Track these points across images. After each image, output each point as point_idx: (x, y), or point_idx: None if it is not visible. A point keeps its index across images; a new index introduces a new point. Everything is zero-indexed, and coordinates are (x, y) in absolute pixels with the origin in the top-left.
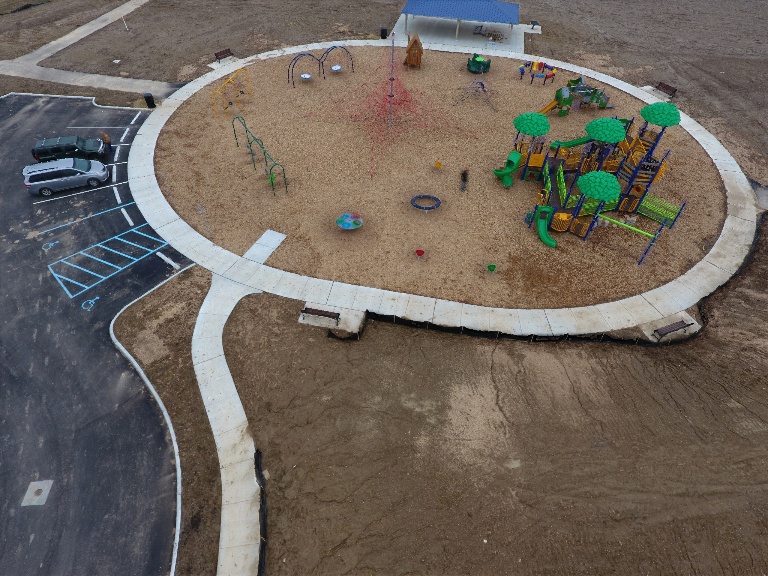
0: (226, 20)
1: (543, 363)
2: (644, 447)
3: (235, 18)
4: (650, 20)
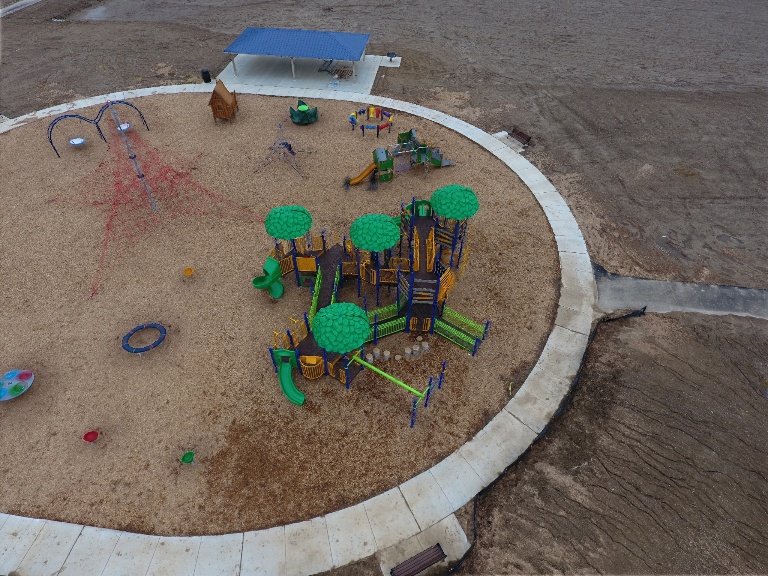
0: (20, 66)
1: None
2: None
3: (33, 63)
4: (530, 44)
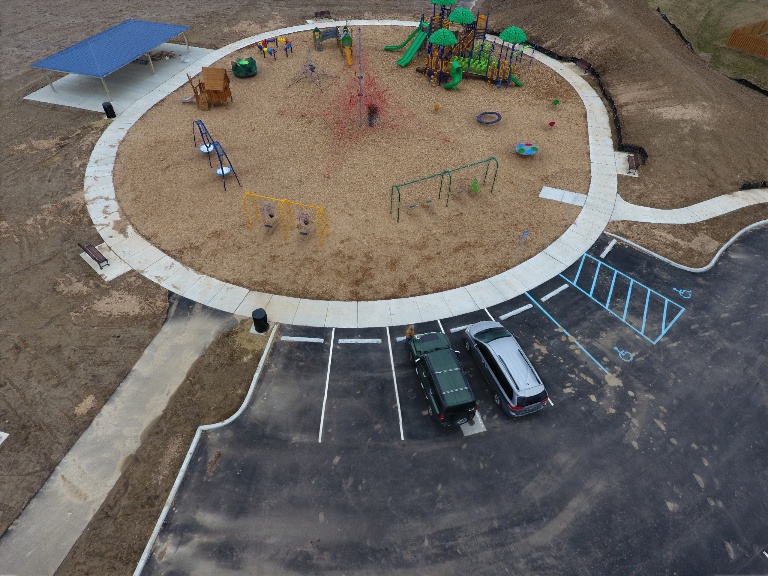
0: None
1: (628, 97)
2: None
3: None
4: None
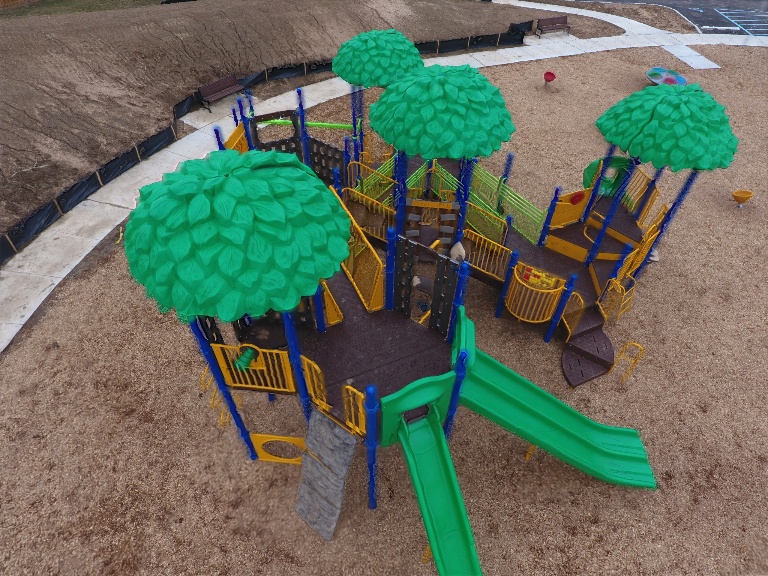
0: None
1: None
2: (266, 3)
3: None
4: None
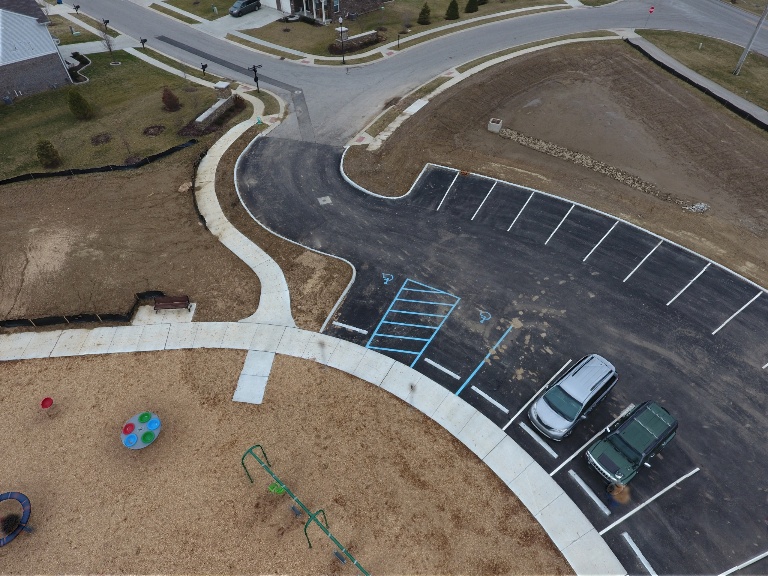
0: None
1: None
2: None
3: None
4: None
